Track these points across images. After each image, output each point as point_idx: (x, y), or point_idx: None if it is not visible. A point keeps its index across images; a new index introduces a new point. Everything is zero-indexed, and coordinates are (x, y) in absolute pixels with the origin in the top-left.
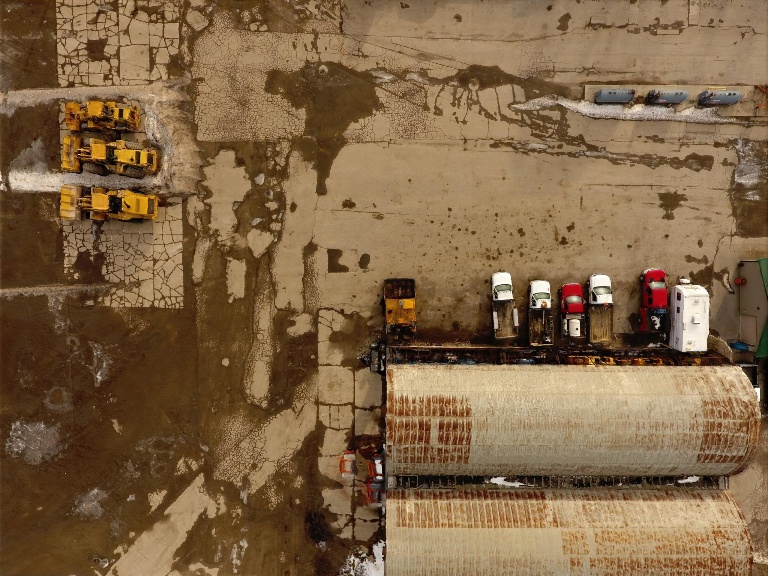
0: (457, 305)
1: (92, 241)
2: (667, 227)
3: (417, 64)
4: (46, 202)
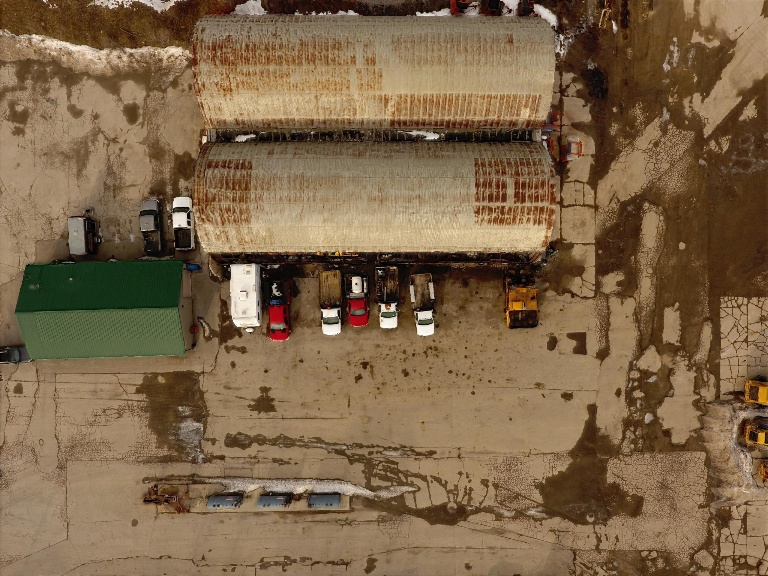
0: (464, 303)
1: None
2: (266, 380)
3: (505, 525)
4: None
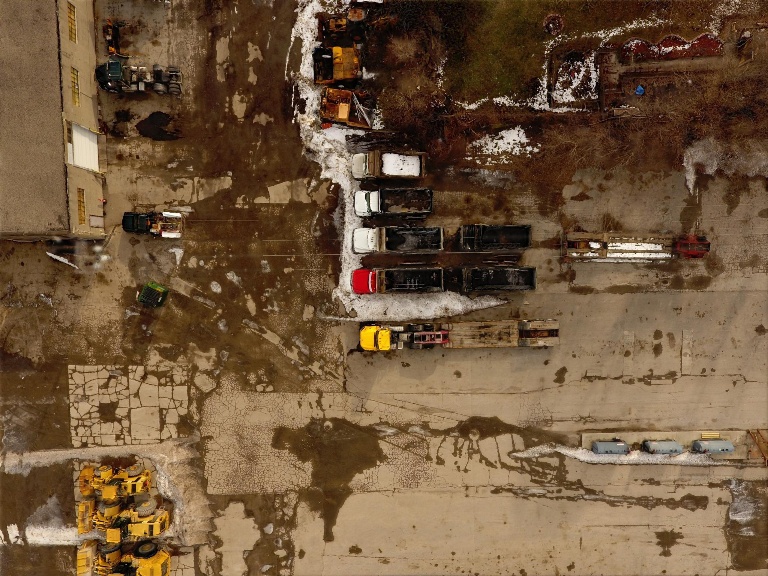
0: None
1: None
2: (664, 563)
3: (419, 418)
4: (62, 554)
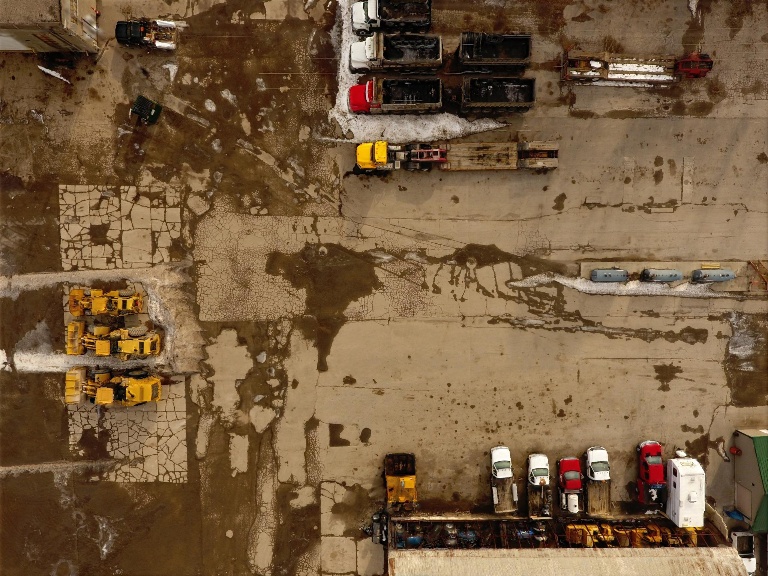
0: (457, 476)
1: (97, 419)
2: (663, 398)
3: (415, 244)
4: (51, 382)
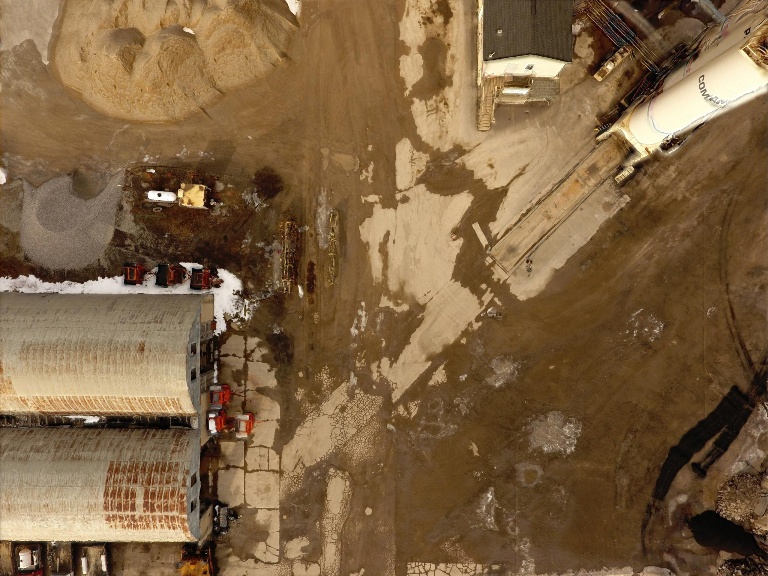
0: (145, 569)
1: None
2: None
3: None
4: None
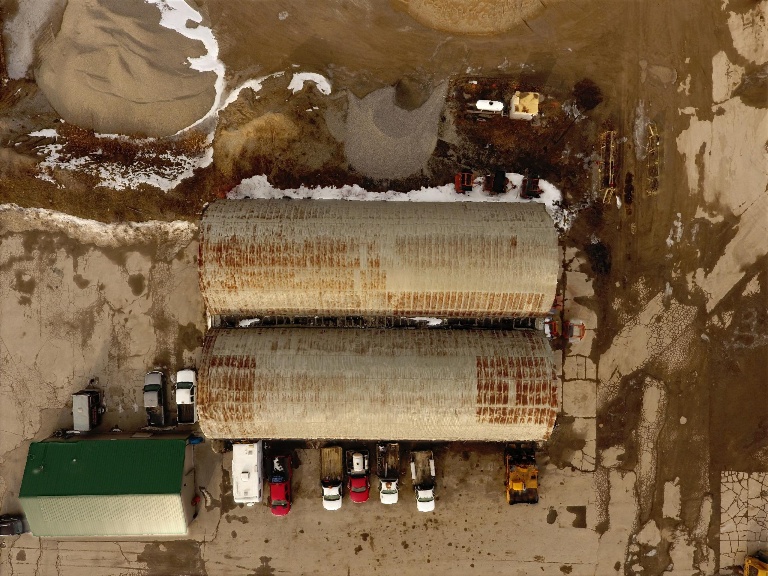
0: (465, 476)
1: None
2: (267, 550)
3: None
4: None
